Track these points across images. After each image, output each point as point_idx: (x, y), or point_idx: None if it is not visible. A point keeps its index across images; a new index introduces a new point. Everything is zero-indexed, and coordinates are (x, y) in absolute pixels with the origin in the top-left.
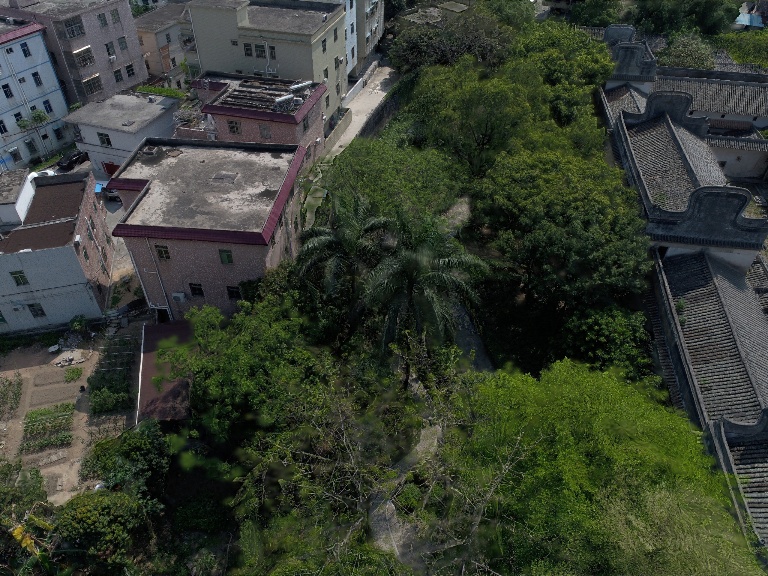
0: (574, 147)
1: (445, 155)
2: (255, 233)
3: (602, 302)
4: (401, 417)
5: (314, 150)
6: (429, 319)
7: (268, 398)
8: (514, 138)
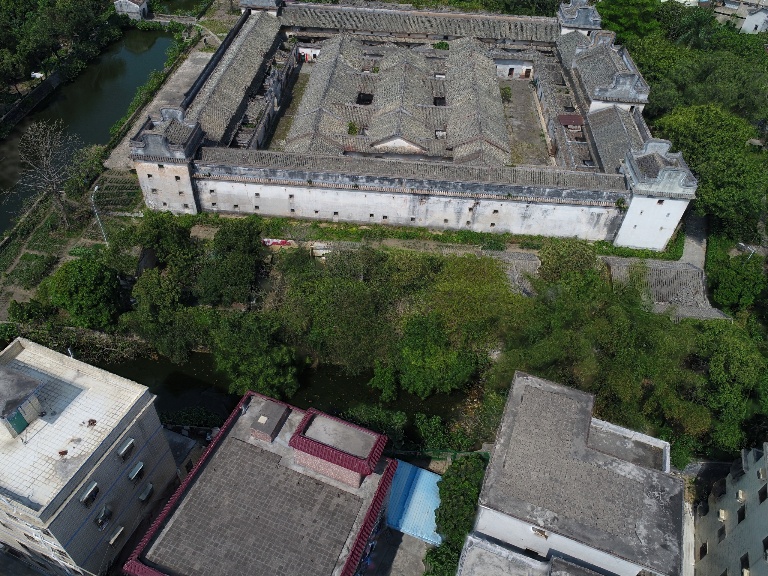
0: None
1: None
2: (765, 44)
3: None
4: None
5: None
6: None
7: None
8: None
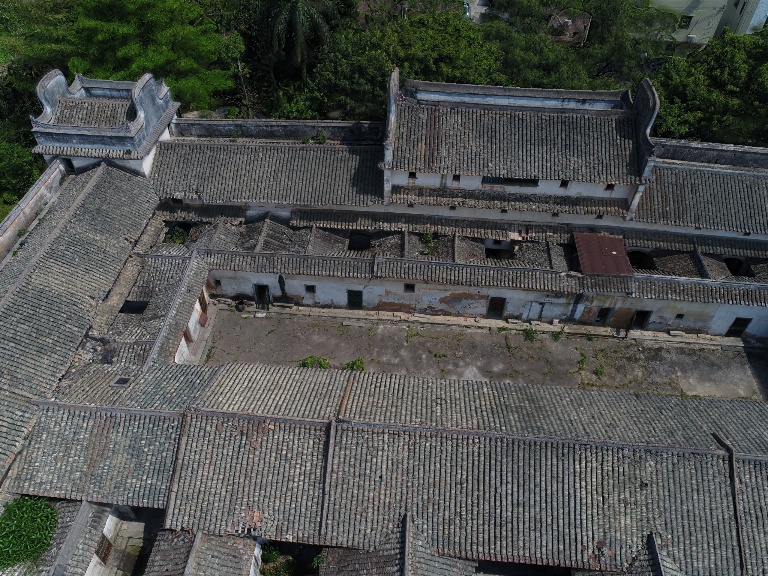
0: (558, 87)
1: (461, 1)
2: None
3: (325, 104)
4: (275, 91)
5: (560, 27)
6: (276, 16)
7: (244, 6)
8: (500, 21)
